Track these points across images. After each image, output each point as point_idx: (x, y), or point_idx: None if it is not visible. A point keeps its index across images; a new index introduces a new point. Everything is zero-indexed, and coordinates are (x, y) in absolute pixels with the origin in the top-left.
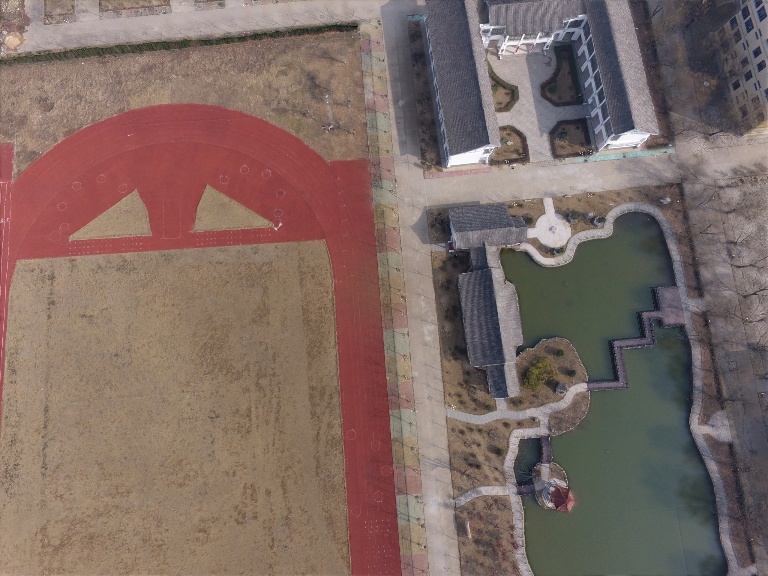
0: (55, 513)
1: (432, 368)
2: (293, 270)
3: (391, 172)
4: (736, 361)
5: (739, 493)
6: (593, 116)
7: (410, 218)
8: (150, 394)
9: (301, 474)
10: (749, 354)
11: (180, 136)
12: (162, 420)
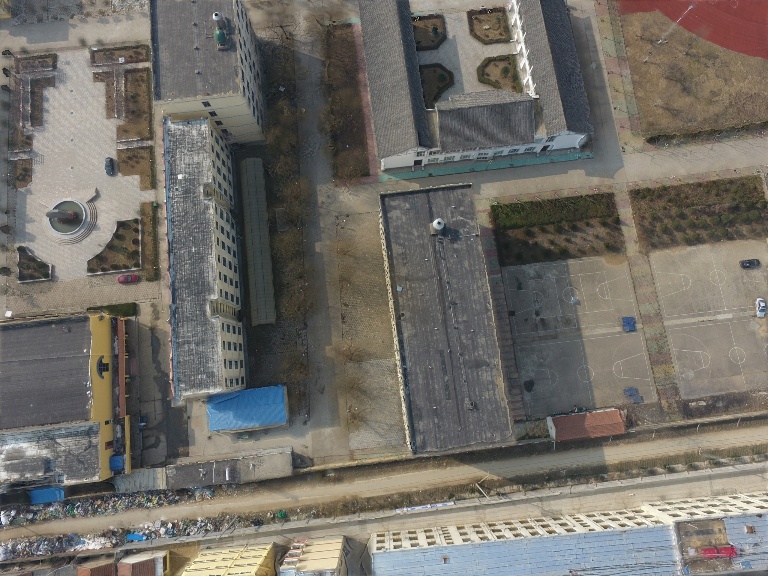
0: None
1: None
2: None
3: (597, 3)
4: None
5: None
6: None
7: None
8: None
9: None
10: None
11: None
12: None
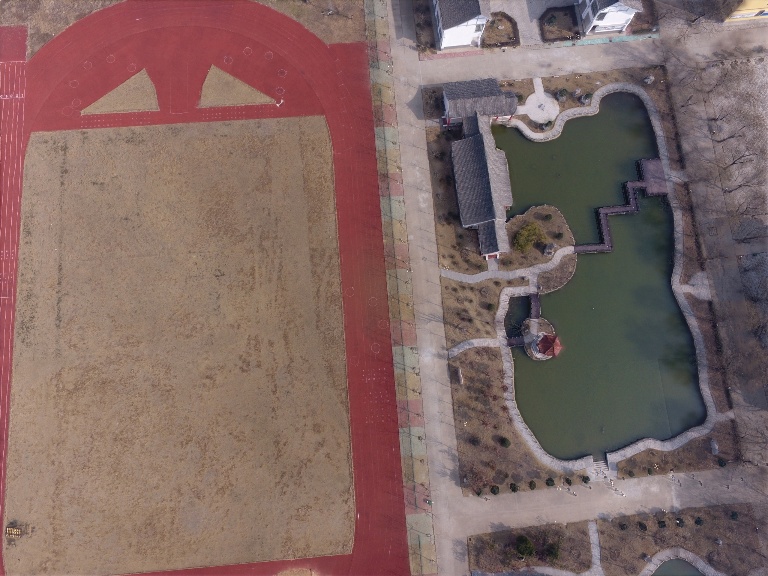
0: (69, 361)
1: (427, 232)
2: (294, 143)
3: (388, 54)
4: (716, 227)
5: (718, 346)
6: (581, 2)
7: (406, 96)
8: (159, 254)
9: (302, 327)
10: (728, 221)
11: (186, 20)
12: (170, 278)
